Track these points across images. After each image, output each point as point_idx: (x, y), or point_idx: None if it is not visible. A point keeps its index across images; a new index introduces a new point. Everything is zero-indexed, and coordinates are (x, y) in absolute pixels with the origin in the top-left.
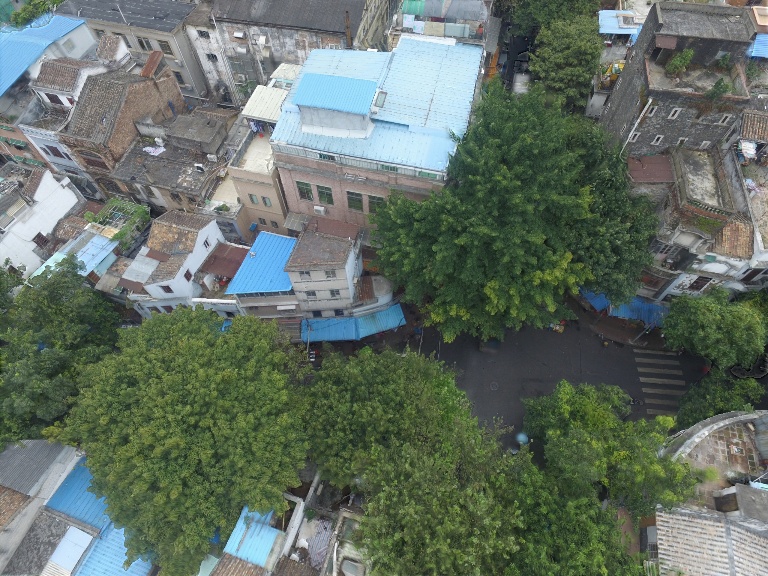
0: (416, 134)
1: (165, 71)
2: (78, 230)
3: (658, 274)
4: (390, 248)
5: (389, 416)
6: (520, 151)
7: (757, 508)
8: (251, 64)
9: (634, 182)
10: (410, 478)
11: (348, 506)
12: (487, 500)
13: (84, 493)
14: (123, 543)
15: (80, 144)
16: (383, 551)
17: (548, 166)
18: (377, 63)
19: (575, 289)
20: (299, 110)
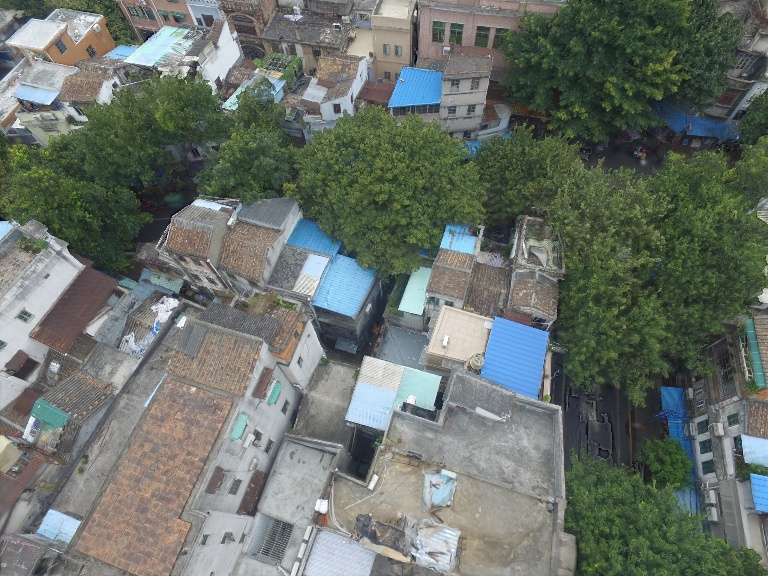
0: None
1: None
2: (250, 74)
3: (735, 86)
4: (528, 55)
5: (554, 153)
6: None
7: None
8: None
9: (720, 1)
10: (583, 178)
11: None
12: None
13: (311, 238)
14: (349, 266)
15: (238, 8)
16: None
17: None
18: None
19: (674, 88)
20: None
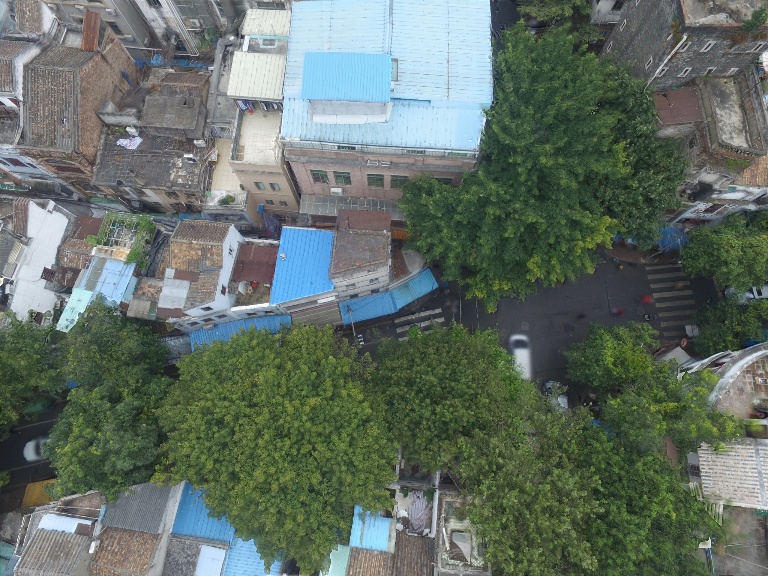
0: (439, 109)
1: (107, 36)
2: (85, 257)
3: None
4: (432, 240)
5: (470, 413)
6: (553, 117)
7: None
8: (205, 8)
9: (662, 125)
10: (504, 468)
11: (441, 484)
12: (573, 476)
13: (201, 515)
14: (251, 547)
15: (47, 155)
16: (494, 532)
17: (585, 132)
18: (376, 16)
19: (608, 244)
20: (309, 102)
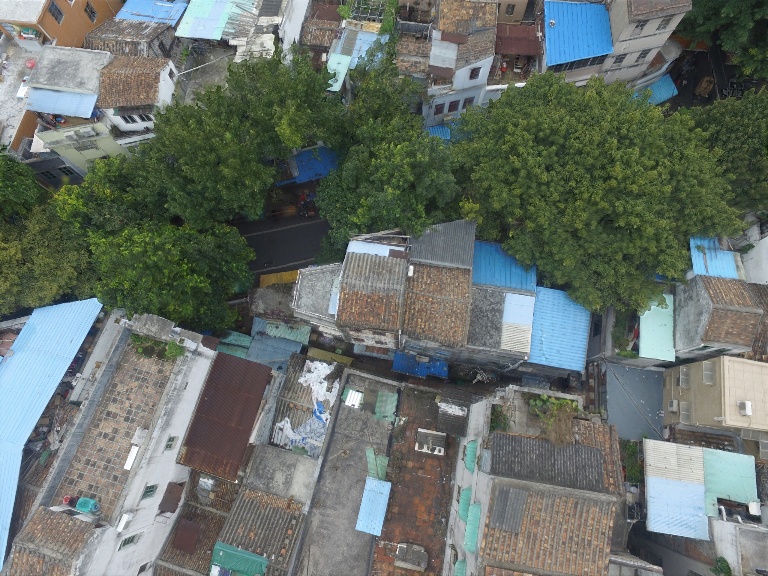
0: None
1: None
2: (336, 29)
3: None
4: None
5: None
6: None
7: None
8: None
9: None
10: None
11: None
12: None
13: (496, 268)
14: (554, 301)
15: None
16: None
17: None
18: None
19: None
20: None
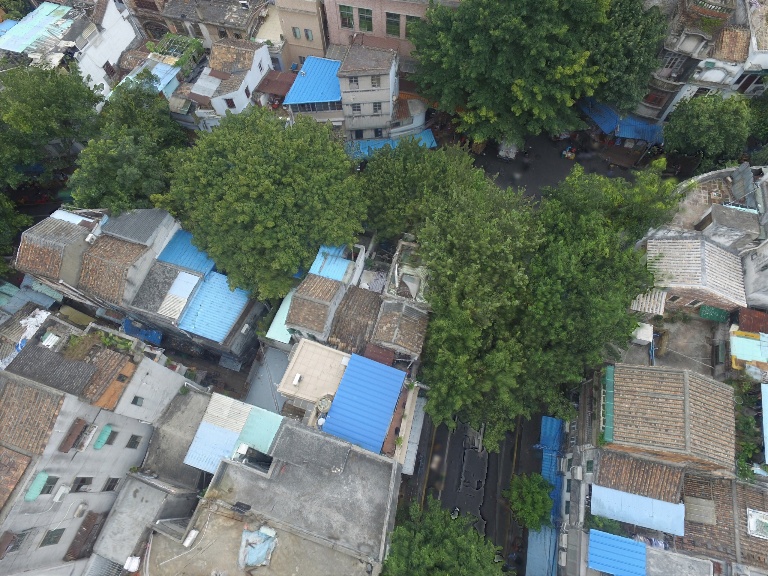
0: None
1: None
2: (142, 59)
3: (663, 87)
4: (430, 52)
5: (436, 171)
6: None
7: (726, 218)
8: None
9: None
10: (457, 204)
11: None
12: (518, 213)
13: (185, 252)
14: (222, 285)
15: None
16: (438, 249)
17: None
18: None
19: (590, 91)
20: None
